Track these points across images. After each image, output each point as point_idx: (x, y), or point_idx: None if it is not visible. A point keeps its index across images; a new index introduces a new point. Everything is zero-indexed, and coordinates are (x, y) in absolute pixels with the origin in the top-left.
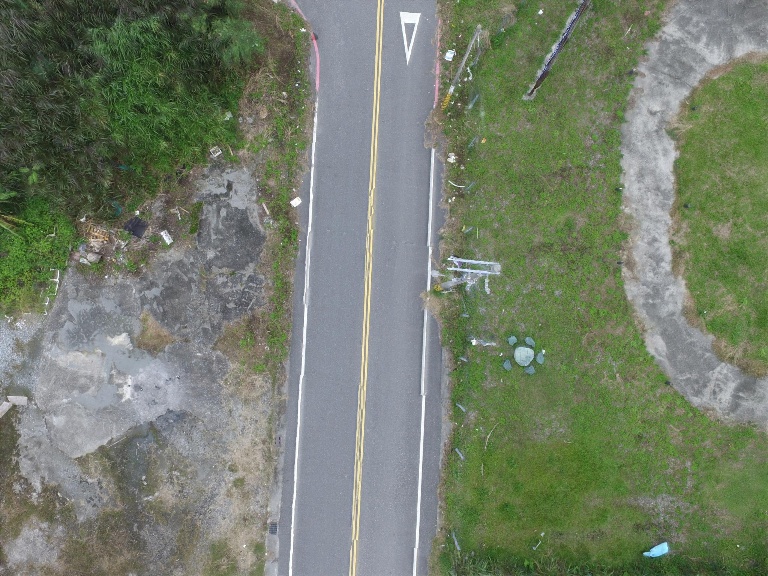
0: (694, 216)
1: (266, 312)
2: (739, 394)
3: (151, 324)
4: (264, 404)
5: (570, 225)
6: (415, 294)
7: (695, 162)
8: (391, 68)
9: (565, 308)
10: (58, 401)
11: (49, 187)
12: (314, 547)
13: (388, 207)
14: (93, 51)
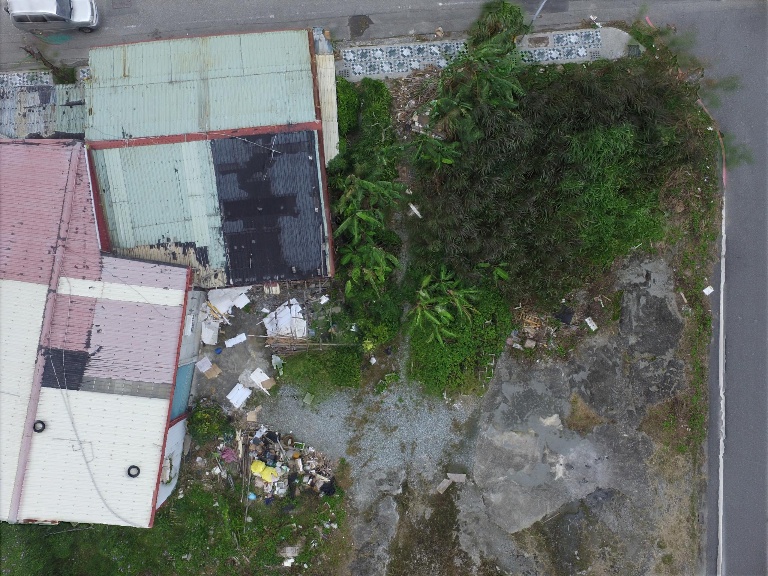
0: None
1: (688, 396)
2: None
3: (580, 406)
4: (686, 483)
5: None
6: None
7: None
8: None
9: None
10: (495, 479)
11: (522, 284)
12: None
13: None
14: (571, 160)
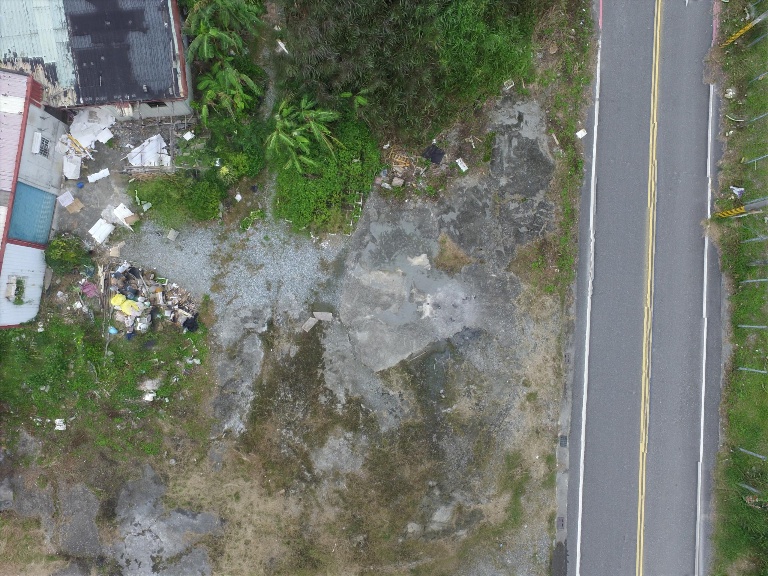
0: None
1: (557, 236)
2: None
3: (448, 246)
4: (554, 324)
5: None
6: (696, 222)
7: None
8: (671, 8)
9: None
10: (361, 317)
11: (380, 109)
12: (604, 459)
13: (669, 139)
14: None
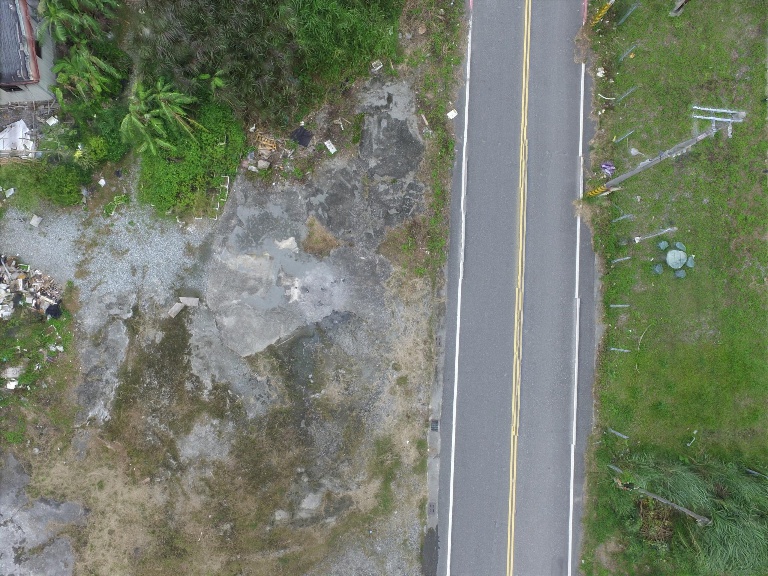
0: None
1: (427, 218)
2: None
3: (317, 229)
4: (425, 306)
5: (717, 135)
6: (568, 202)
7: None
8: None
9: (713, 215)
10: (228, 302)
11: (234, 90)
12: (475, 443)
13: (541, 119)
14: None
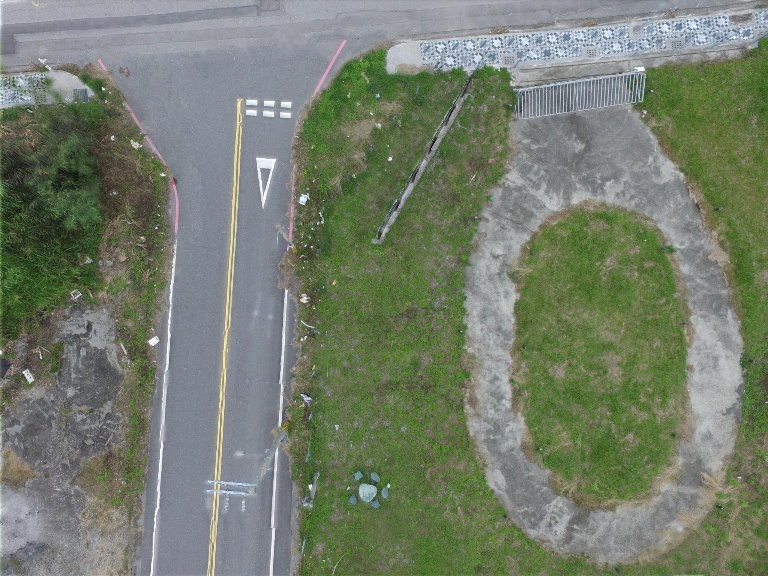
0: (532, 356)
1: (123, 449)
2: (574, 526)
3: (12, 460)
4: (120, 537)
5: (415, 364)
6: (267, 430)
7: (534, 305)
8: (247, 212)
9: (410, 443)
10: None
11: None
12: None
13: (242, 346)
14: None
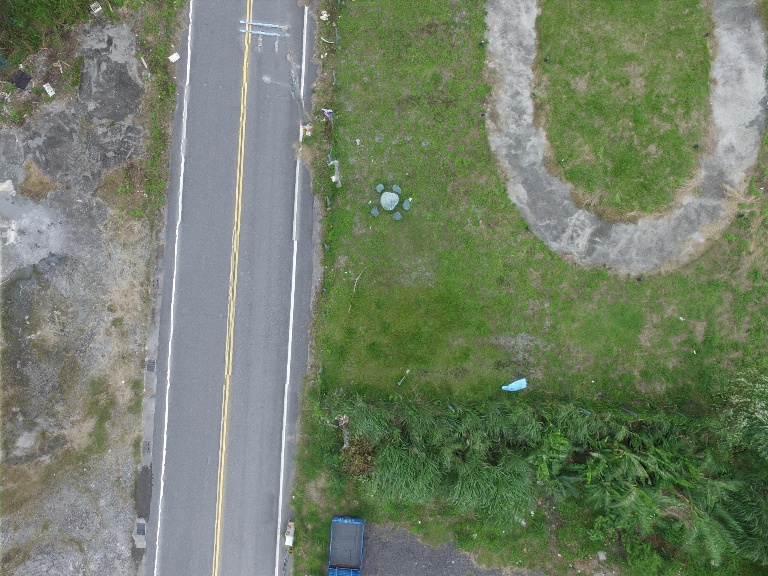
0: (554, 70)
1: (144, 160)
2: (596, 239)
3: (33, 172)
4: (143, 249)
5: (436, 79)
6: (288, 145)
7: (555, 18)
8: None
9: (431, 158)
10: None
11: None
12: (189, 383)
13: (263, 62)
14: None
